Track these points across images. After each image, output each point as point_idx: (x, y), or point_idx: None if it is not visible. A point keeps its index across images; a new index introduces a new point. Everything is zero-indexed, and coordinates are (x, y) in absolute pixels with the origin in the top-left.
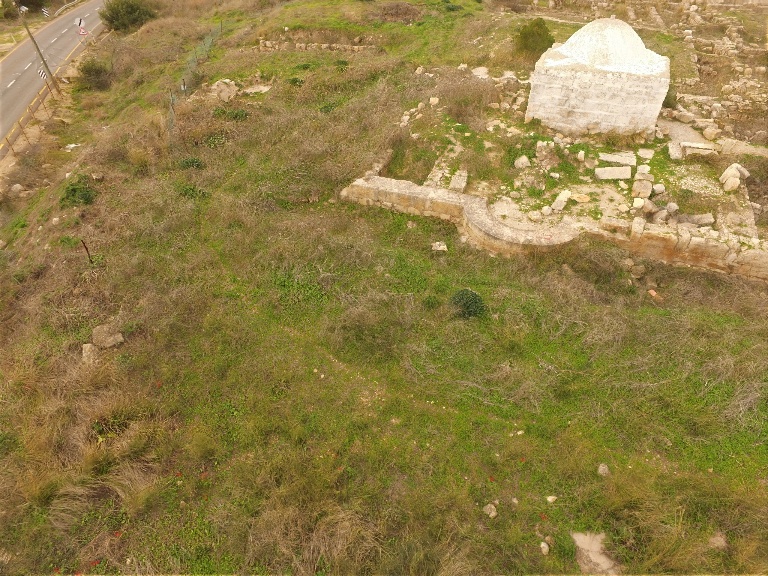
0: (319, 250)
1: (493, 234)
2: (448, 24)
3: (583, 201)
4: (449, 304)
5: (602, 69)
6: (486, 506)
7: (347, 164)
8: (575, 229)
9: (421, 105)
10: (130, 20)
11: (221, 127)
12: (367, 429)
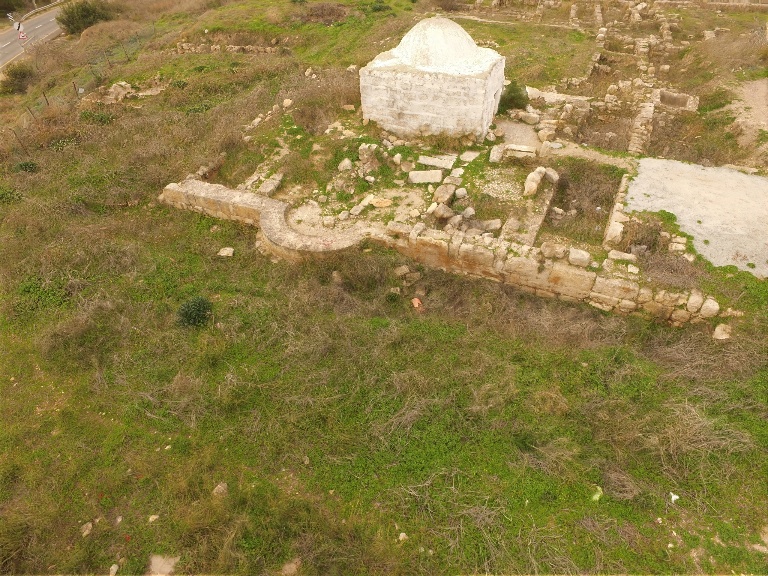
0: (78, 255)
1: (273, 239)
2: (366, 24)
3: (381, 206)
4: (177, 312)
5: (421, 70)
6: (85, 524)
7: (172, 167)
8: (361, 235)
9: (275, 107)
10: (85, 24)
11: (74, 130)
12: (18, 440)
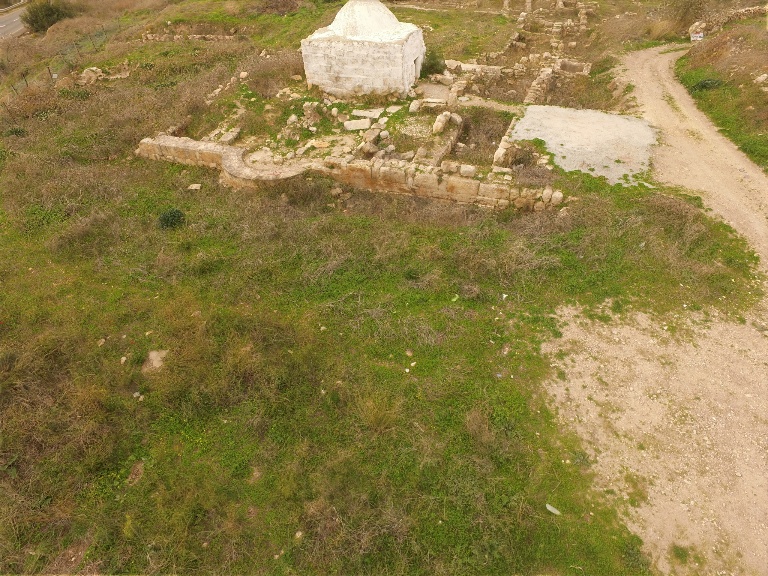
0: (73, 187)
1: (233, 173)
2: (316, 14)
3: (321, 146)
4: None
5: (351, 39)
6: (99, 340)
7: (145, 127)
8: (304, 167)
9: (233, 79)
10: (49, 22)
11: (55, 103)
12: (42, 301)
